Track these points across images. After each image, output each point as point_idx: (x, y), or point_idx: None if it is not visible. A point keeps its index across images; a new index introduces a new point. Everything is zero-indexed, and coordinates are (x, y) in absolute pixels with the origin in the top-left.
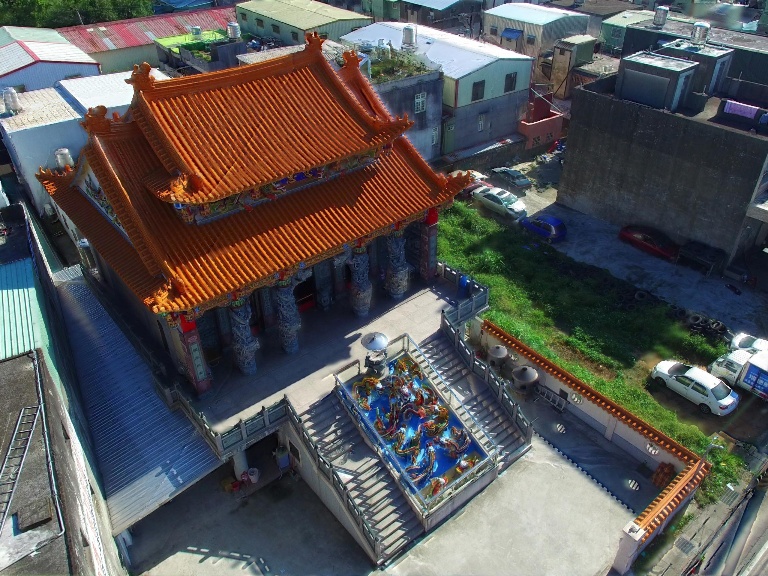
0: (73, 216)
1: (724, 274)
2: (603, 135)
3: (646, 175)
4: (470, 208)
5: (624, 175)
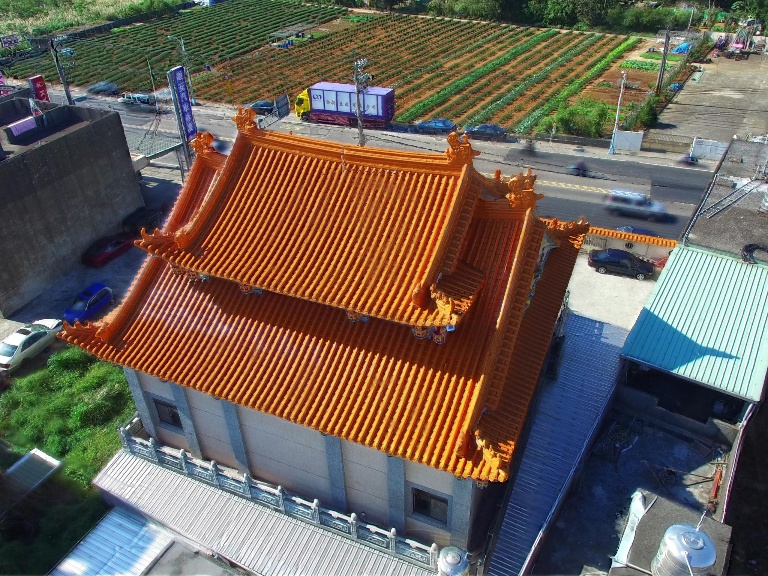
0: (534, 375)
1: (152, 221)
2: (7, 209)
3: (64, 207)
4: (37, 370)
5: (48, 225)
